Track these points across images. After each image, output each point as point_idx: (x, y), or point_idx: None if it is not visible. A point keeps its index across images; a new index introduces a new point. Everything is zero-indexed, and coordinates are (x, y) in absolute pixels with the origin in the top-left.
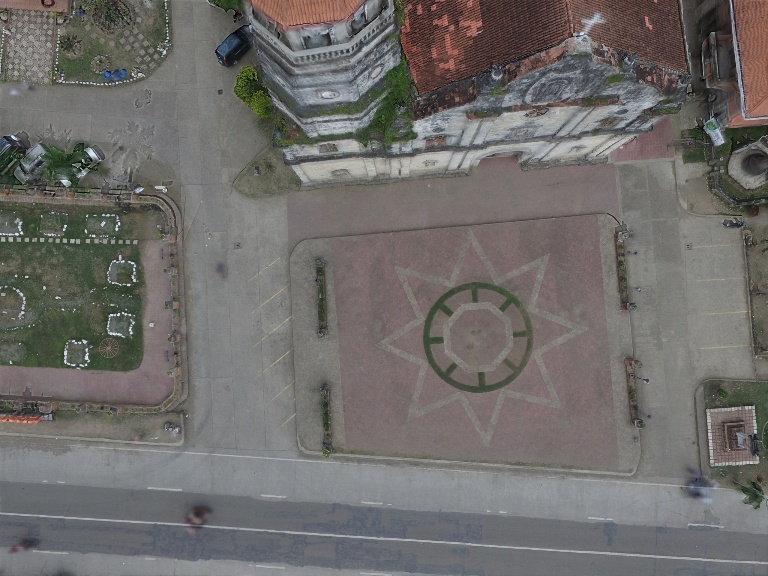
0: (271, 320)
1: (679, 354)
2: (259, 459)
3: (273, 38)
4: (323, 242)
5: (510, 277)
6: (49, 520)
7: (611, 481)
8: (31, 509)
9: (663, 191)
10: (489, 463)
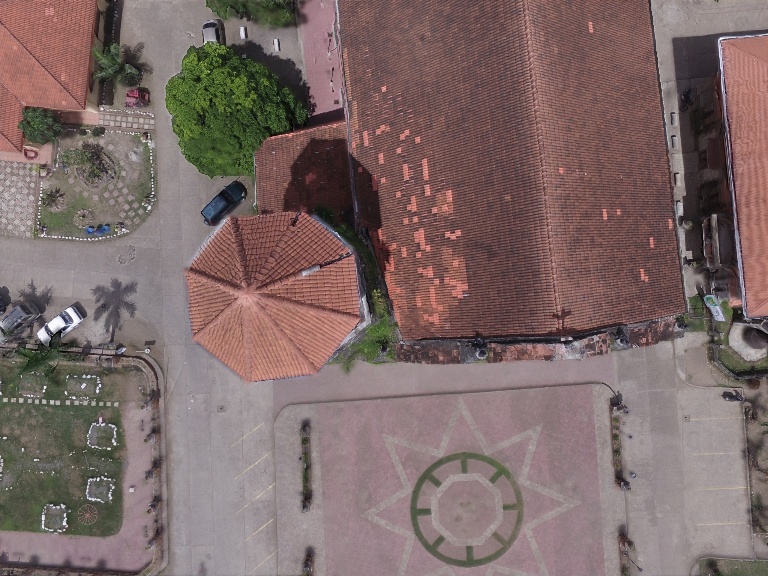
0: (254, 487)
1: (674, 530)
2: None
3: None
4: (309, 408)
5: (501, 448)
6: None
7: None
8: None
9: (661, 361)
10: None
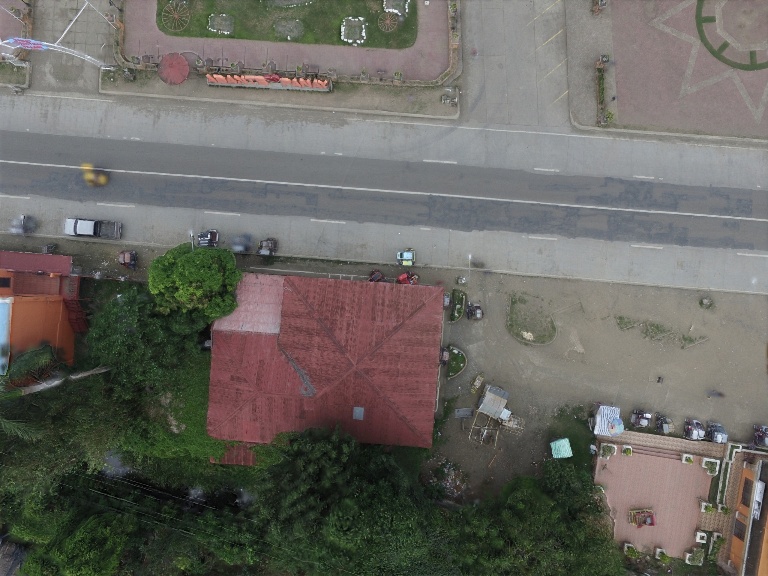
0: None
1: None
2: (532, 134)
3: None
4: None
5: None
6: (327, 190)
7: None
8: (309, 179)
9: None
10: (760, 139)
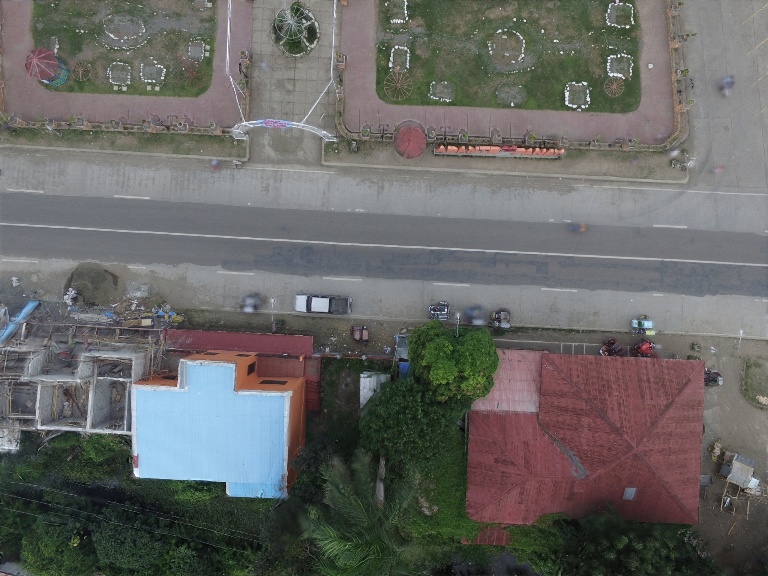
0: (767, 61)
1: None
2: (762, 196)
3: None
4: None
5: None
6: (557, 258)
7: None
8: (539, 247)
9: None
10: None
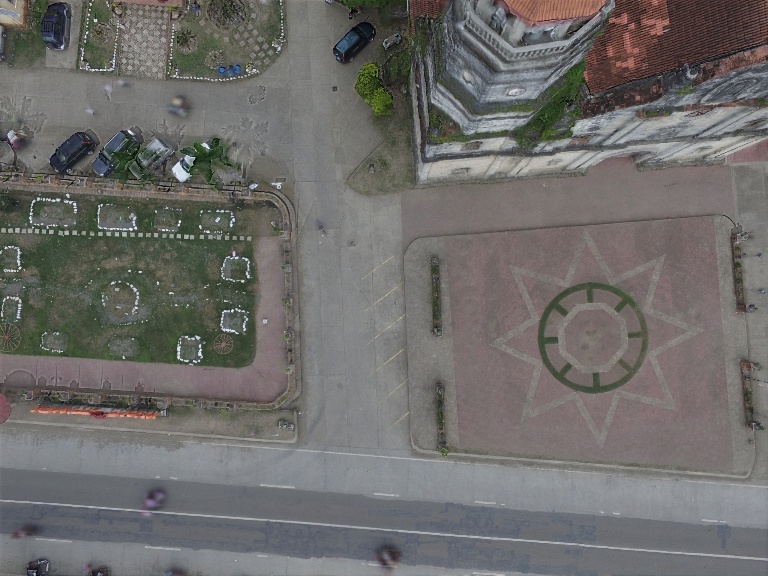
0: (385, 318)
1: None
2: (372, 457)
3: (492, 34)
4: (438, 240)
5: (625, 278)
6: (161, 516)
7: (725, 483)
8: (143, 505)
9: None
10: (603, 464)
